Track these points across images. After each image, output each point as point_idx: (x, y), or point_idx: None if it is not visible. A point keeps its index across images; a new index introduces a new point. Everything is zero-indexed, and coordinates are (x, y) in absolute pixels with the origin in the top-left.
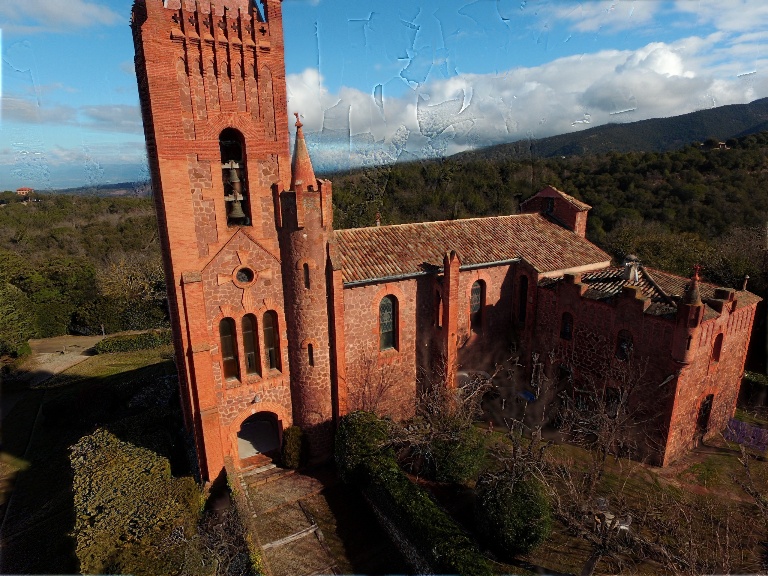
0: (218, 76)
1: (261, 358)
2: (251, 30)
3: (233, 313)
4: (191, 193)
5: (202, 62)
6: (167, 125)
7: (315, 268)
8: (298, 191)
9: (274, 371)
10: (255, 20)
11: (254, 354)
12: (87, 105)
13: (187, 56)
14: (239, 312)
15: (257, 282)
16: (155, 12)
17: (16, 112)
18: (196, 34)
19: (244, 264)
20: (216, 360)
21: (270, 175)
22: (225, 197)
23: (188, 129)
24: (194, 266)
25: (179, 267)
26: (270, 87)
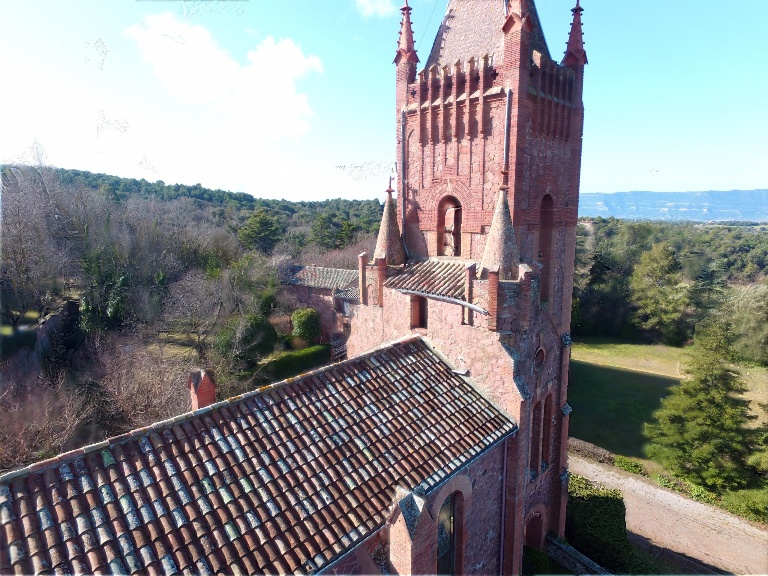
0: None
1: None
2: None
3: None
4: None
5: None
6: None
7: None
8: None
9: None
10: None
11: None
12: None
13: None
14: None
15: None
16: None
17: None
18: None
19: None
20: None
21: None
22: None
23: None
24: None
25: None
26: None
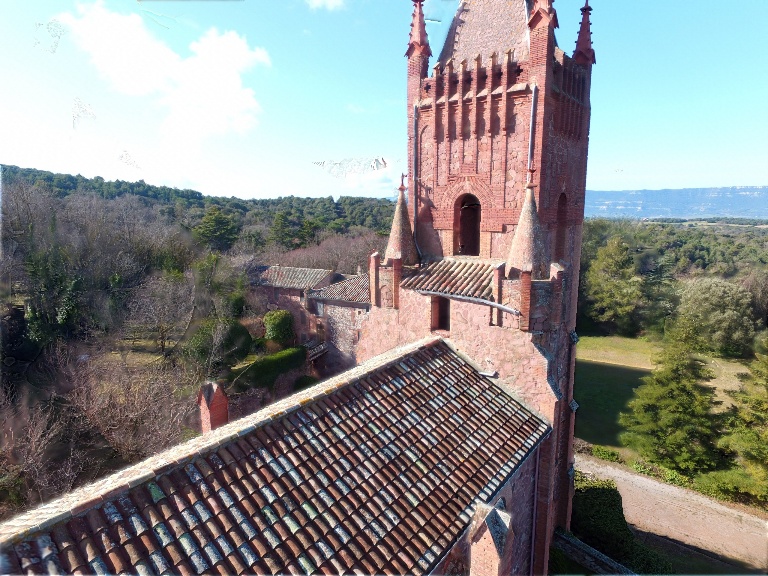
0: None
1: None
2: None
3: None
4: None
5: None
6: None
7: None
8: None
9: None
10: None
11: None
12: None
13: None
14: None
15: None
16: None
17: None
18: None
19: None
20: None
21: None
22: None
23: None
24: None
25: None
26: None
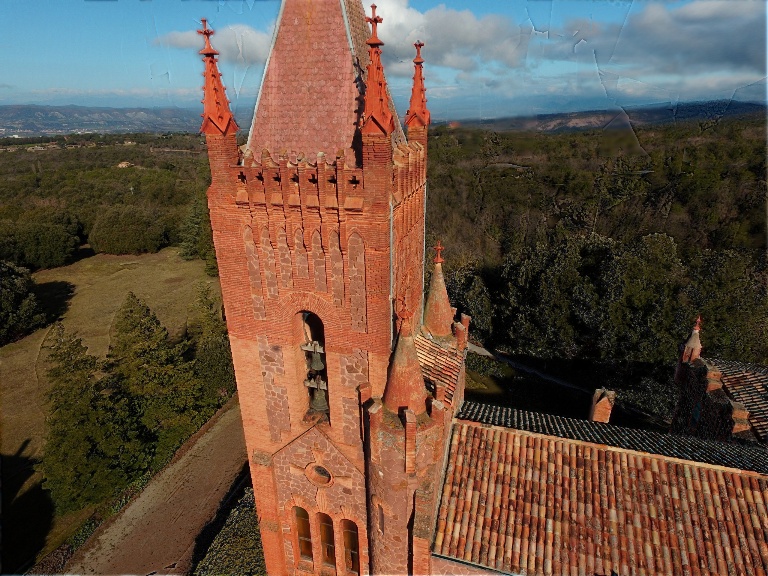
0: (290, 248)
1: (336, 559)
2: (336, 183)
3: (306, 505)
4: (262, 375)
5: (269, 232)
6: (236, 301)
7: (392, 516)
8: (372, 420)
9: (354, 575)
10: (339, 170)
11: (334, 547)
12: (457, 84)
13: (252, 225)
14: (313, 507)
15: (334, 486)
16: (220, 173)
17: (395, 99)
18: (263, 196)
19: (319, 463)
20: (288, 539)
21: (357, 373)
22: (306, 382)
23: (258, 307)
24: (266, 447)
25: (251, 443)
26: (362, 261)
